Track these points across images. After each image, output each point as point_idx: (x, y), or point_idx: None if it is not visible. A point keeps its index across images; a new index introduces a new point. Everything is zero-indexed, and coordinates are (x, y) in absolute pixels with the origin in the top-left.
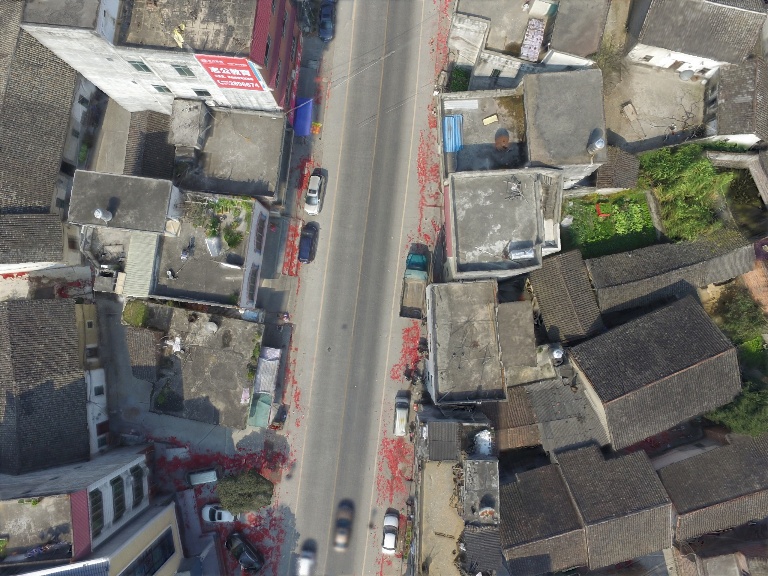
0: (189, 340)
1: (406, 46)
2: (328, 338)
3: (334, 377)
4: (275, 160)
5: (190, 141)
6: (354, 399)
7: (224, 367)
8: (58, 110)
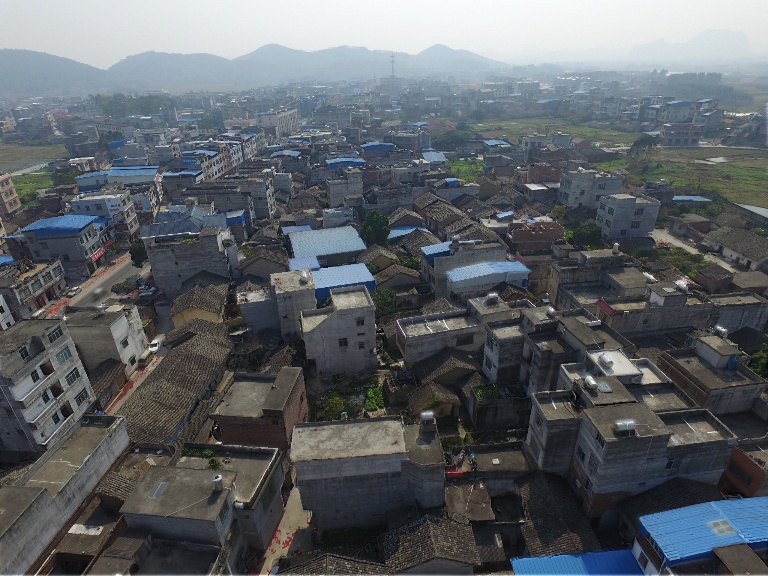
0: None
1: None
2: None
3: None
4: None
5: None
6: None
7: None
8: None
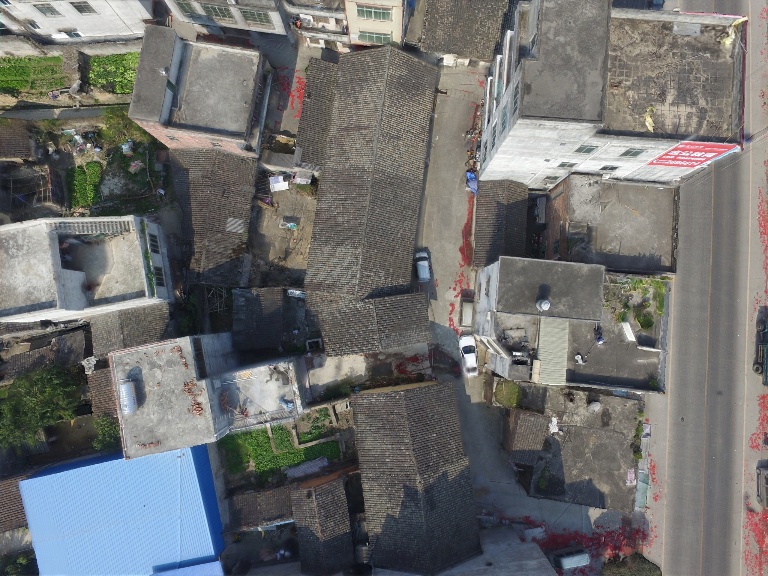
0: (566, 420)
1: None
2: (680, 407)
3: (690, 448)
4: (666, 232)
5: (593, 218)
6: (713, 471)
7: (605, 447)
8: (414, 182)
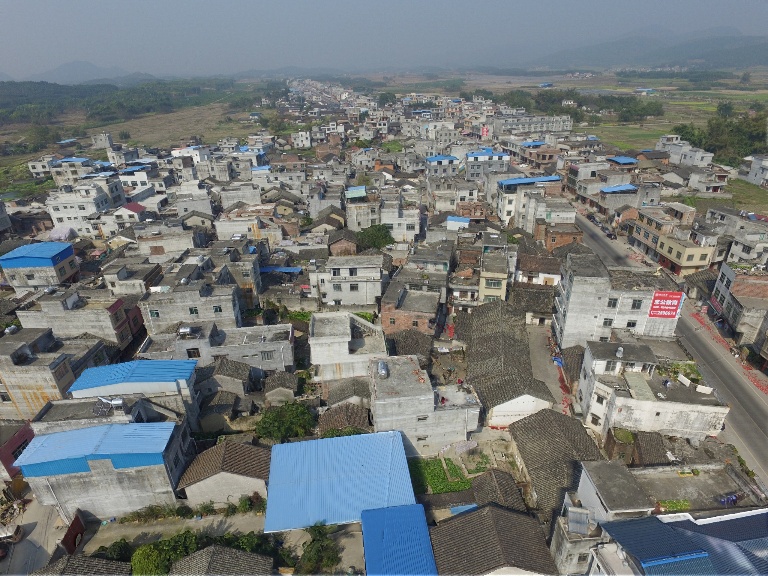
0: (678, 453)
1: (699, 340)
2: None
3: None
4: None
5: (633, 342)
6: None
7: None
8: (524, 343)
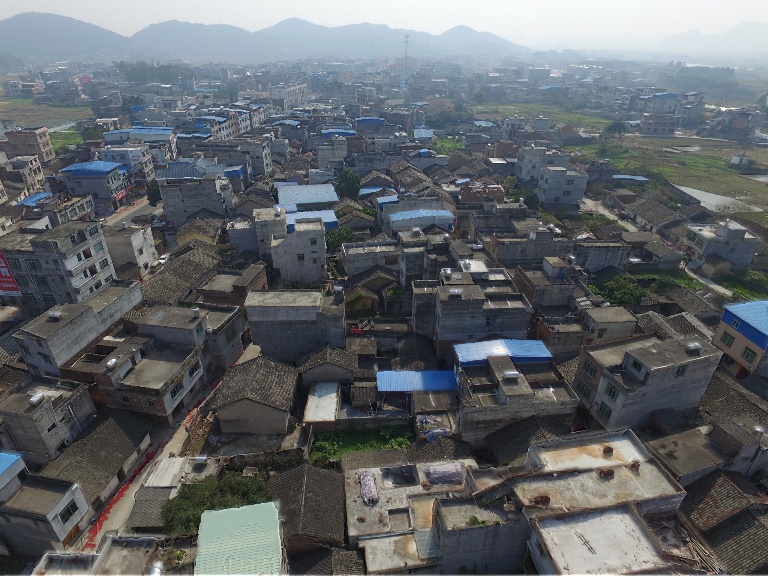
0: None
1: None
2: None
3: None
4: None
5: None
6: None
7: None
8: None
